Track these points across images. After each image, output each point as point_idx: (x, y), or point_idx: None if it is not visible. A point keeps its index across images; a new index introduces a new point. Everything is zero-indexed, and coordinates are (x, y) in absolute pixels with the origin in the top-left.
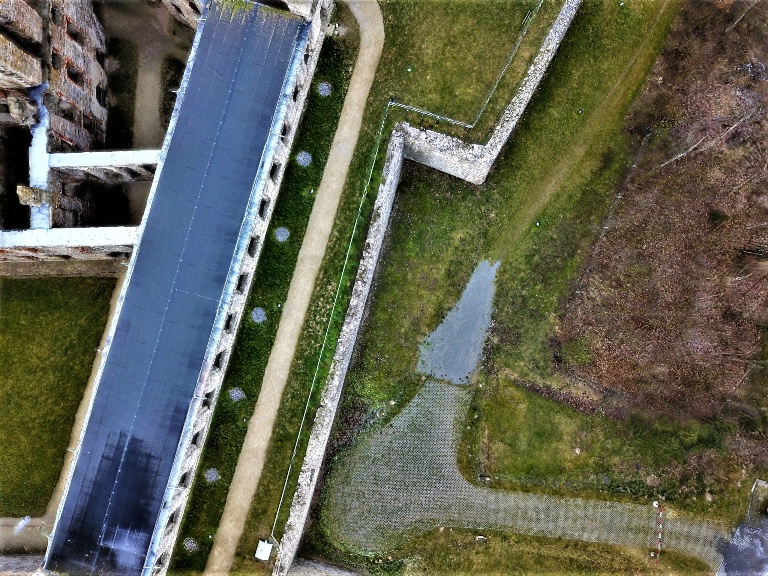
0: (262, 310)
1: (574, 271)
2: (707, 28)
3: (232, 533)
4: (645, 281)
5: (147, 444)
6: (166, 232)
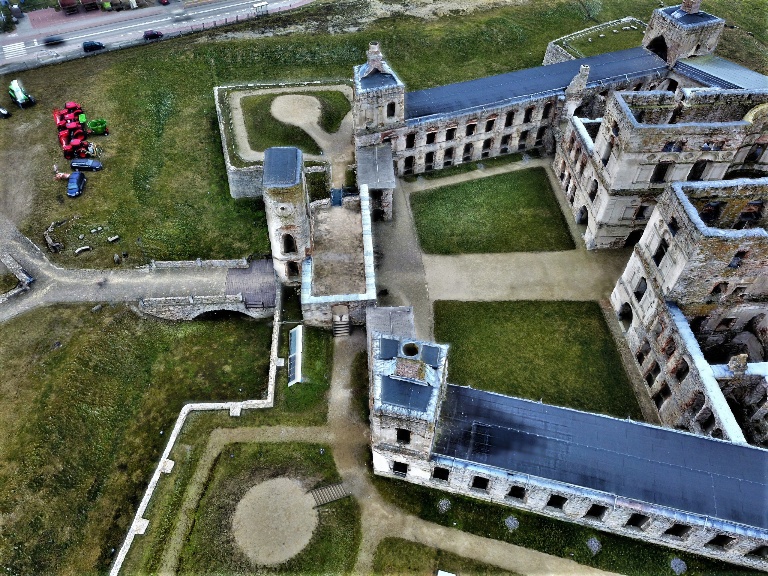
0: (685, 570)
1: None
2: None
3: (459, 545)
4: None
5: (566, 457)
6: (759, 466)
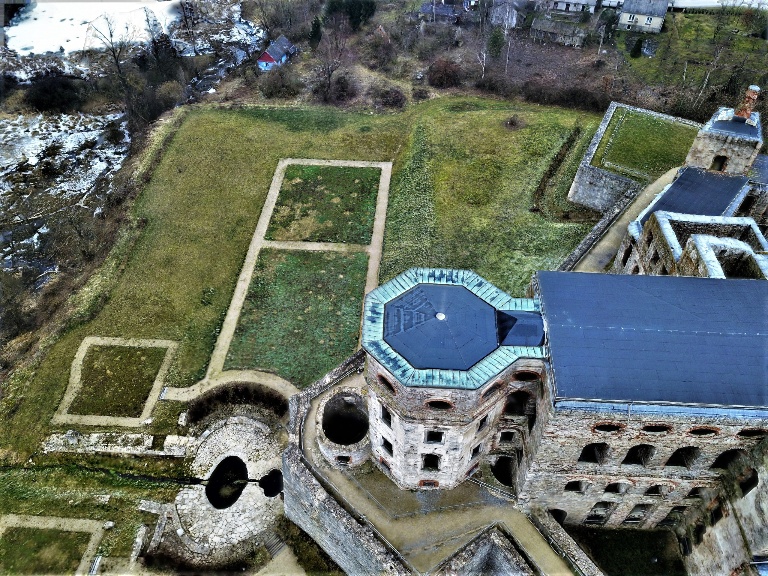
0: None
1: (767, 139)
2: (614, 98)
3: None
4: (760, 117)
5: None
6: None
